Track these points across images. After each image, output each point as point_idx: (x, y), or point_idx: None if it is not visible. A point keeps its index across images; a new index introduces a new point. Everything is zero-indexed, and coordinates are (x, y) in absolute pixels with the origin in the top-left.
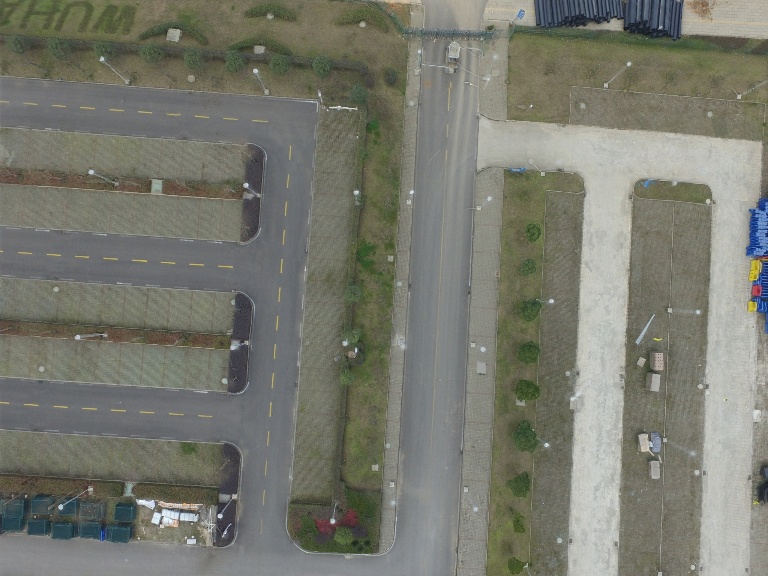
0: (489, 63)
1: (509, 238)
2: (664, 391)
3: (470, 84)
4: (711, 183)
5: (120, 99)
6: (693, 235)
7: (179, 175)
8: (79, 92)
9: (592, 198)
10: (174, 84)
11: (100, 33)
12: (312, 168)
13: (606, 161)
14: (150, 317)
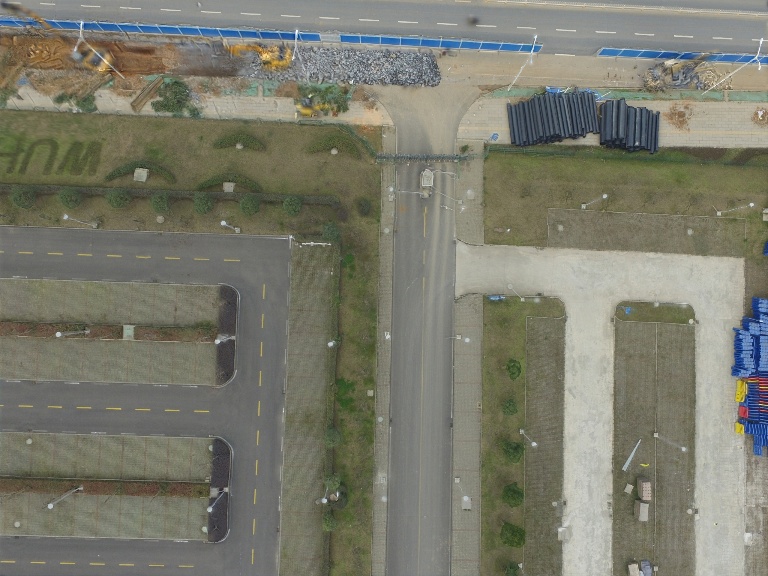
0: (464, 185)
1: (490, 367)
2: (653, 518)
3: (446, 208)
4: (693, 302)
5: (88, 243)
6: (677, 356)
7: (151, 319)
8: (46, 237)
9: (573, 322)
10: (143, 226)
11: (66, 175)
12: (287, 306)
13: (586, 284)
14: (126, 466)
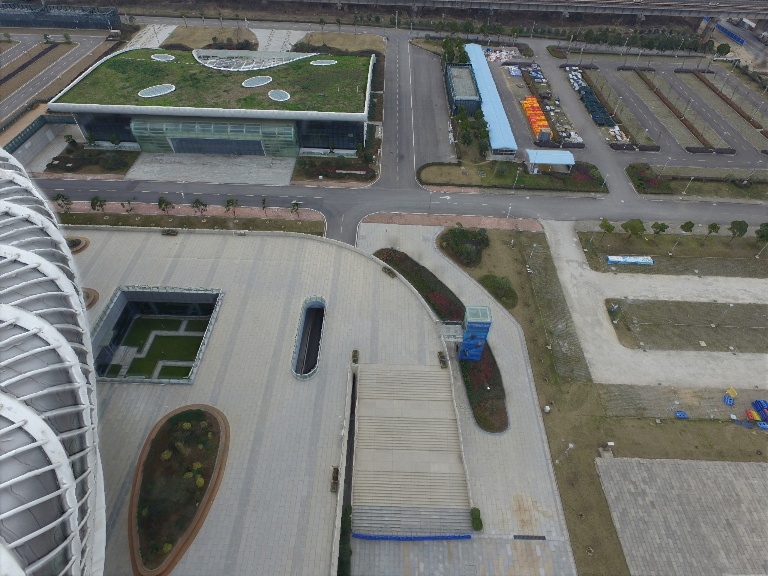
0: None
1: None
2: None
3: None
4: None
5: None
6: None
7: None
8: None
9: None
10: None
11: None
12: None
13: None
14: None
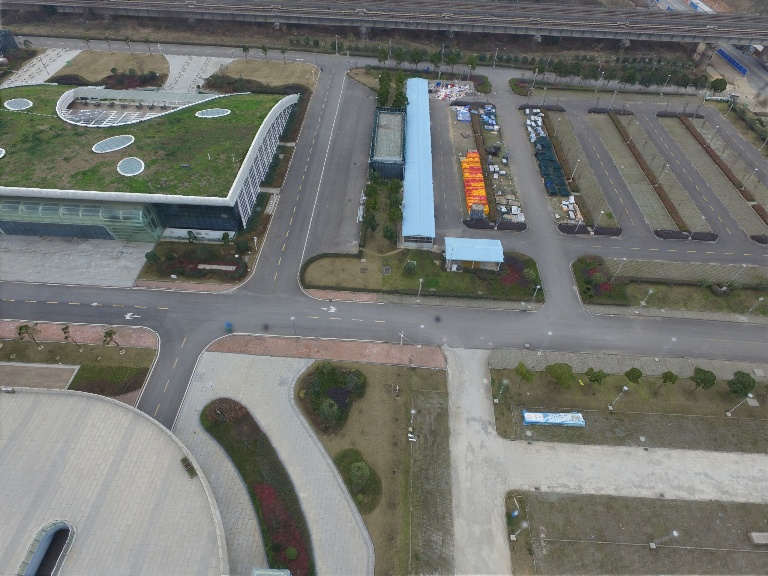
0: None
1: None
2: None
3: None
4: None
5: None
6: None
7: None
8: None
9: None
10: None
11: None
12: None
13: None
14: (676, 202)
